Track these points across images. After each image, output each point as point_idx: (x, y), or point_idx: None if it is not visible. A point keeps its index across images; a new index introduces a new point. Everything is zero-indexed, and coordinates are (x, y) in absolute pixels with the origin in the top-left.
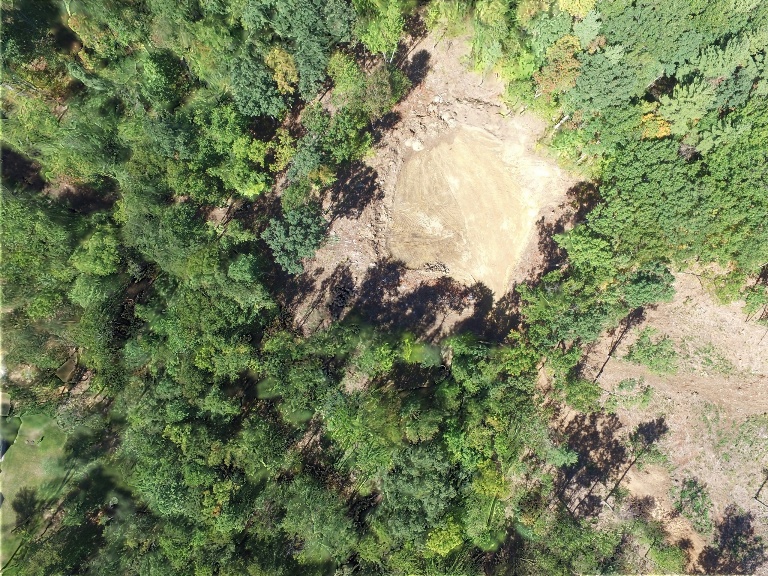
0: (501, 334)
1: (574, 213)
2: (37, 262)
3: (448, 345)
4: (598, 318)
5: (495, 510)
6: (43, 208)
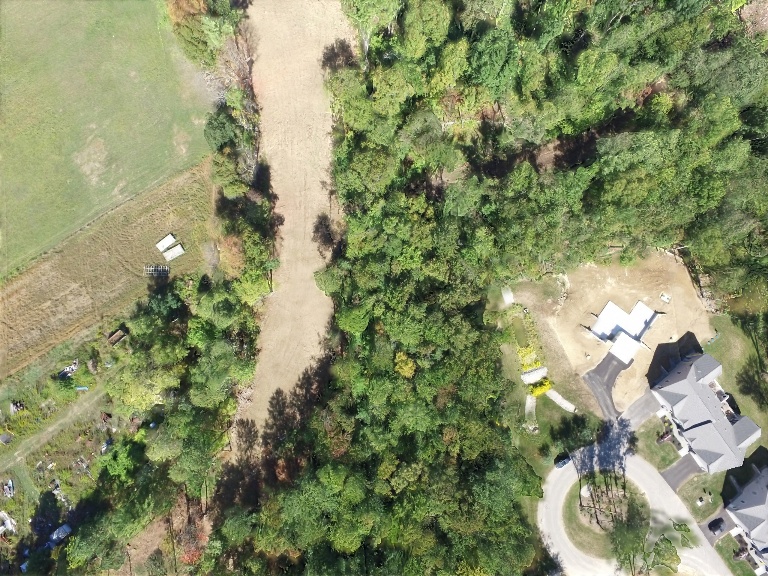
0: None
1: None
2: None
3: None
4: None
5: None
6: None
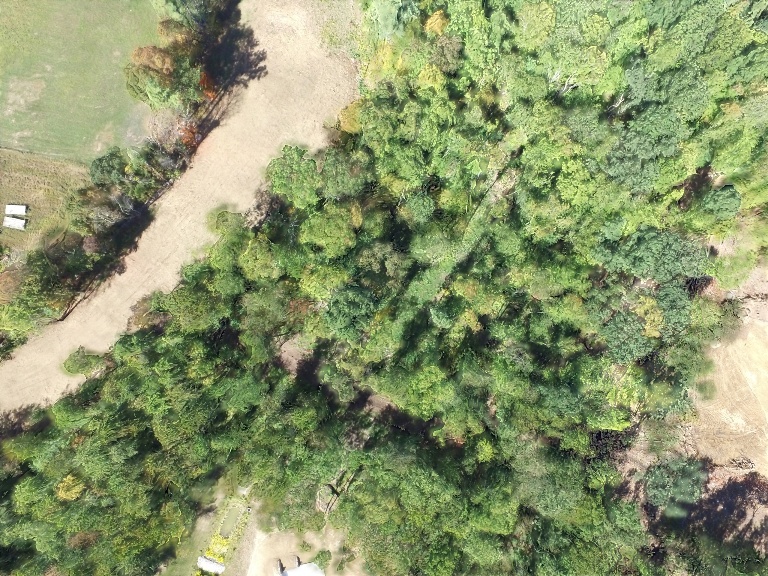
0: None
1: None
2: (429, 519)
3: (760, 539)
4: None
5: None
6: (424, 461)
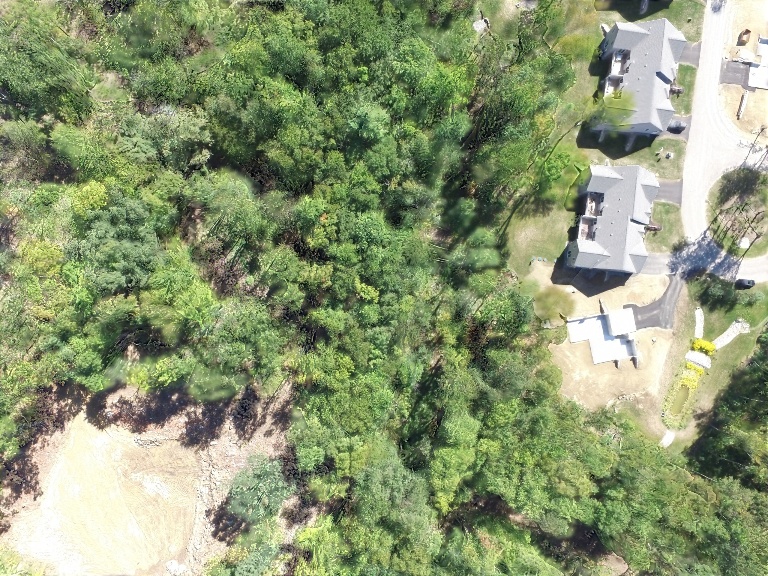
0: None
1: (1, 507)
2: (516, 456)
3: (132, 365)
4: None
5: None
6: None
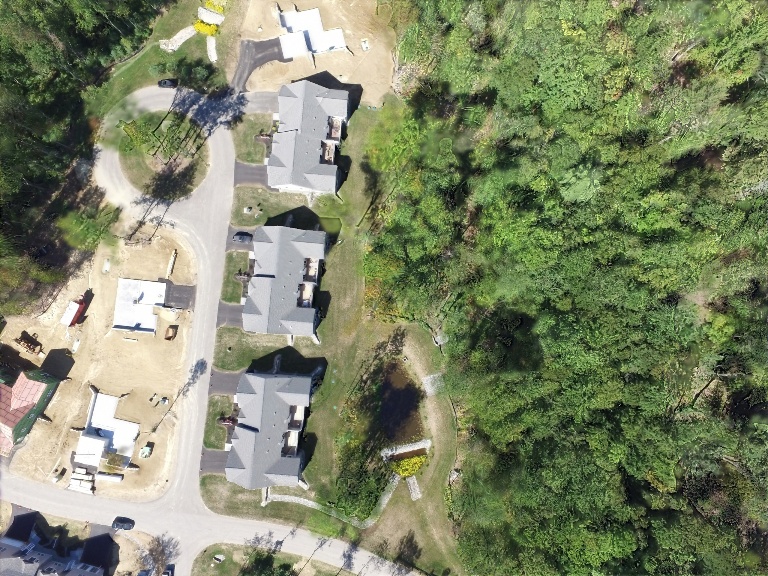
0: None
1: None
2: None
3: None
4: None
5: None
6: None
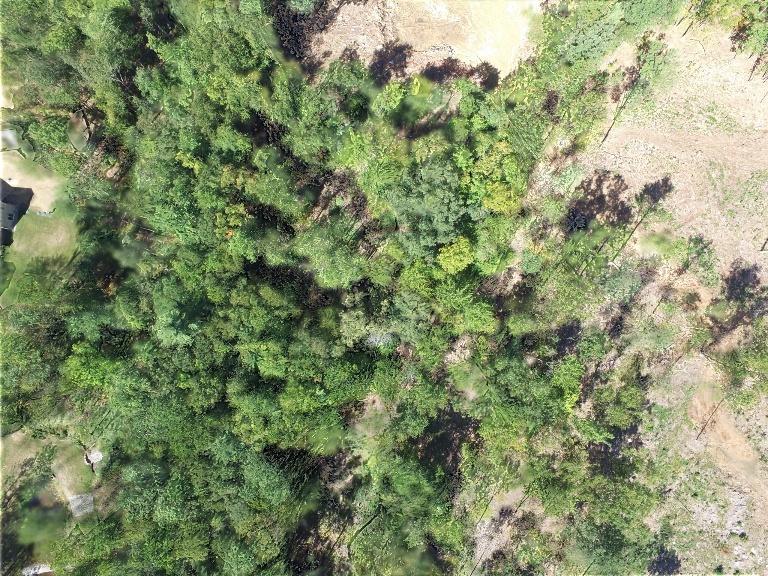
0: (507, 108)
1: None
2: (51, 0)
3: None
4: (603, 86)
5: (503, 276)
6: None
